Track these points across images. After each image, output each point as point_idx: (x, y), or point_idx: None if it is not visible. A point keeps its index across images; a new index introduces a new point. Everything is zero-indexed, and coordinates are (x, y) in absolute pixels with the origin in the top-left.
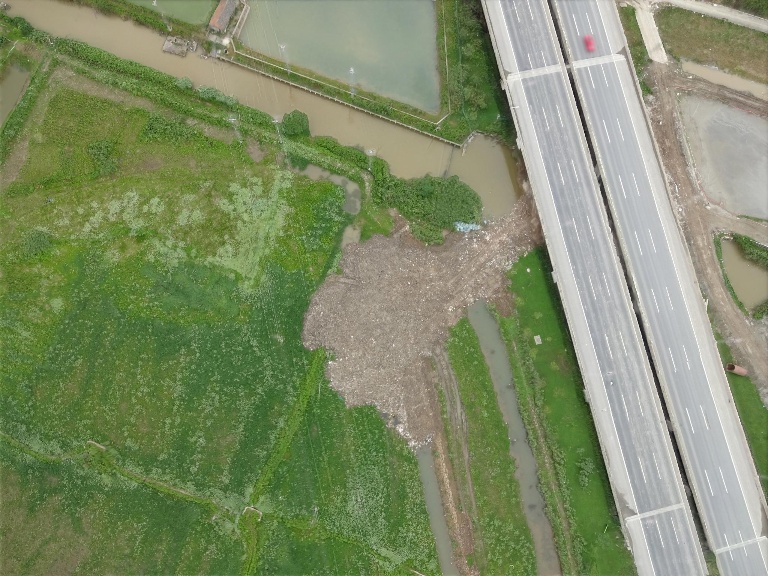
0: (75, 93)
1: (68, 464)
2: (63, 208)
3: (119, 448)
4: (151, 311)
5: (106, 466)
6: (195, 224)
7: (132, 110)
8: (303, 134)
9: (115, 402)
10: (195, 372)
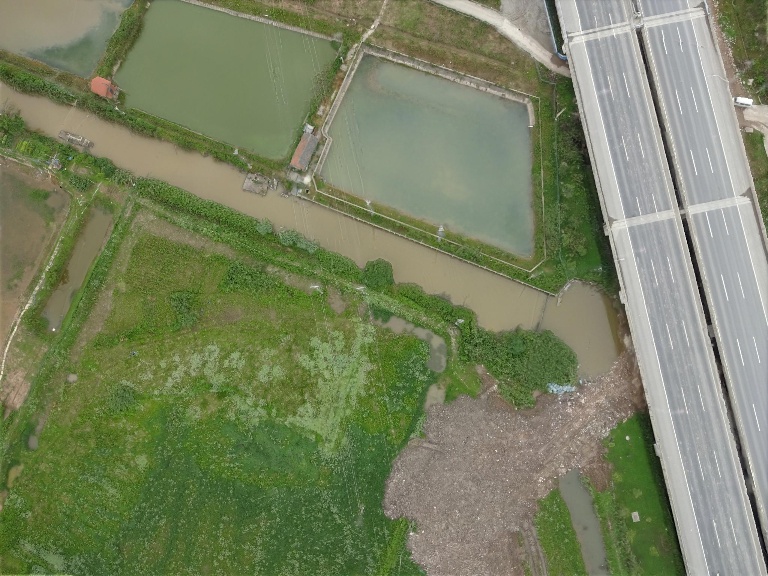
0: (157, 239)
1: None
2: (146, 361)
3: None
4: (232, 472)
5: None
6: (275, 381)
7: (213, 258)
8: (386, 283)
9: (198, 564)
10: (275, 538)
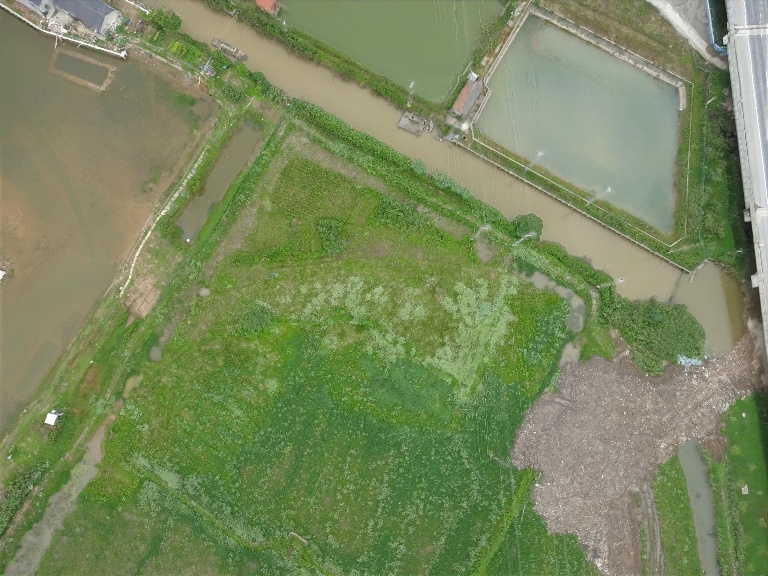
0: (309, 163)
1: (269, 553)
2: (286, 284)
3: (320, 543)
4: (365, 406)
5: (307, 561)
6: (417, 320)
7: (365, 190)
8: None
9: (320, 495)
10: (402, 476)
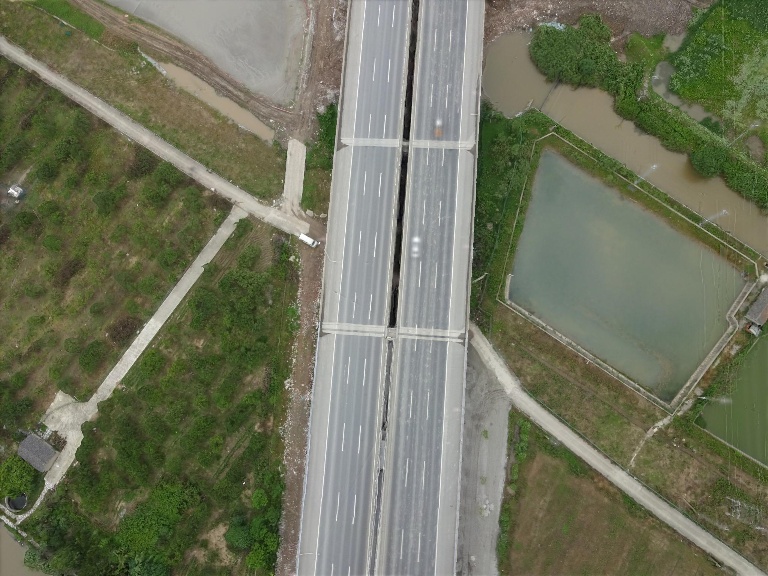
0: None
1: None
2: None
3: None
4: None
5: None
6: None
7: None
8: None
9: None
10: None
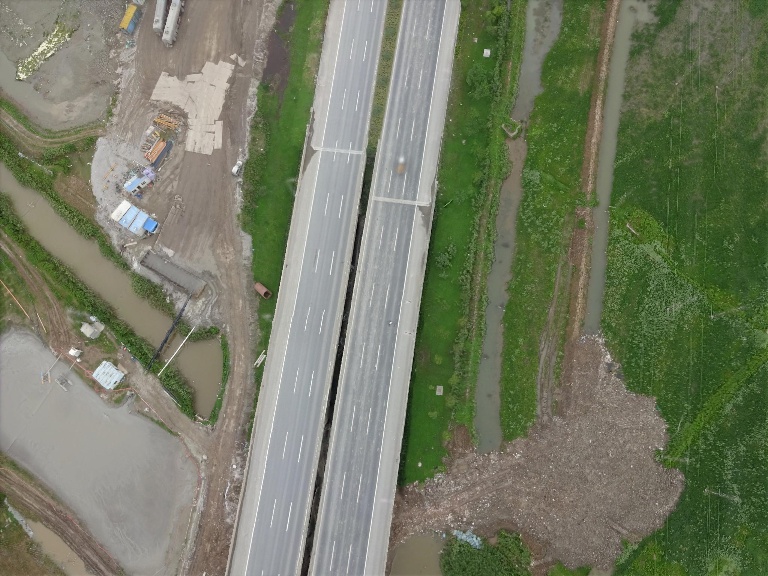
0: None
1: None
2: None
3: None
4: None
5: None
6: None
7: None
8: None
9: None
10: None
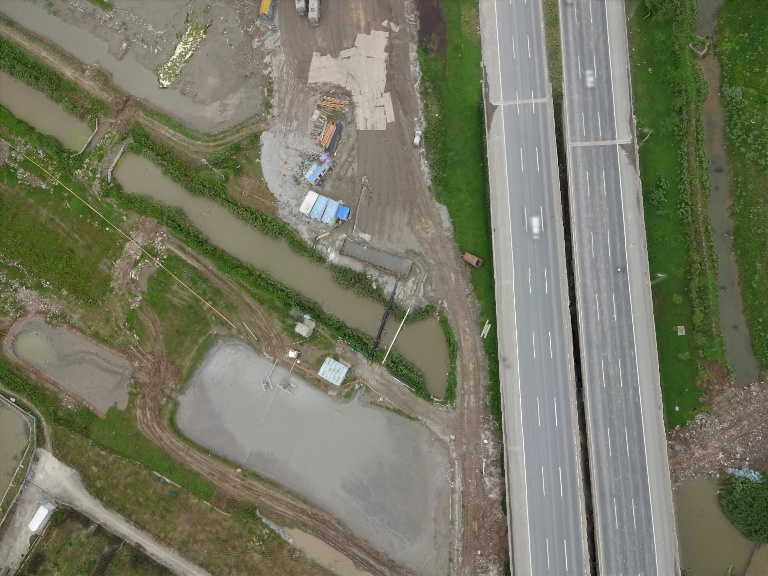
0: None
1: None
2: None
3: None
4: None
5: None
6: None
7: None
8: None
9: None
10: None
